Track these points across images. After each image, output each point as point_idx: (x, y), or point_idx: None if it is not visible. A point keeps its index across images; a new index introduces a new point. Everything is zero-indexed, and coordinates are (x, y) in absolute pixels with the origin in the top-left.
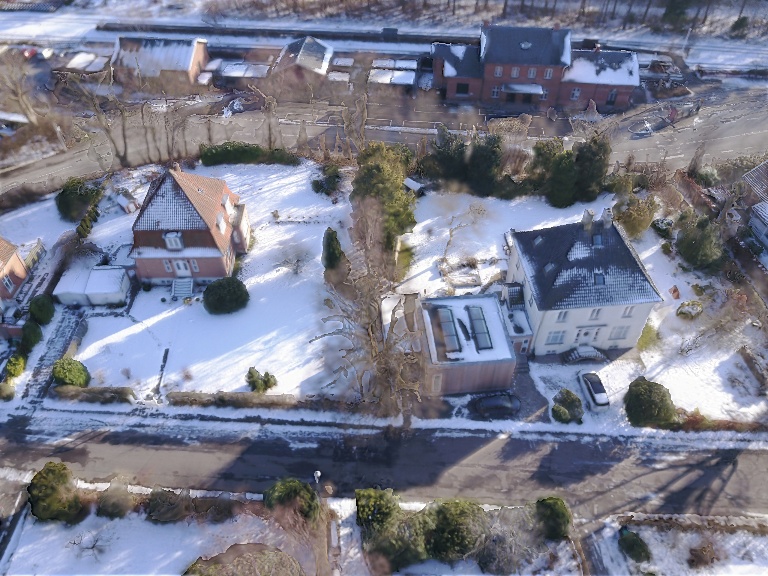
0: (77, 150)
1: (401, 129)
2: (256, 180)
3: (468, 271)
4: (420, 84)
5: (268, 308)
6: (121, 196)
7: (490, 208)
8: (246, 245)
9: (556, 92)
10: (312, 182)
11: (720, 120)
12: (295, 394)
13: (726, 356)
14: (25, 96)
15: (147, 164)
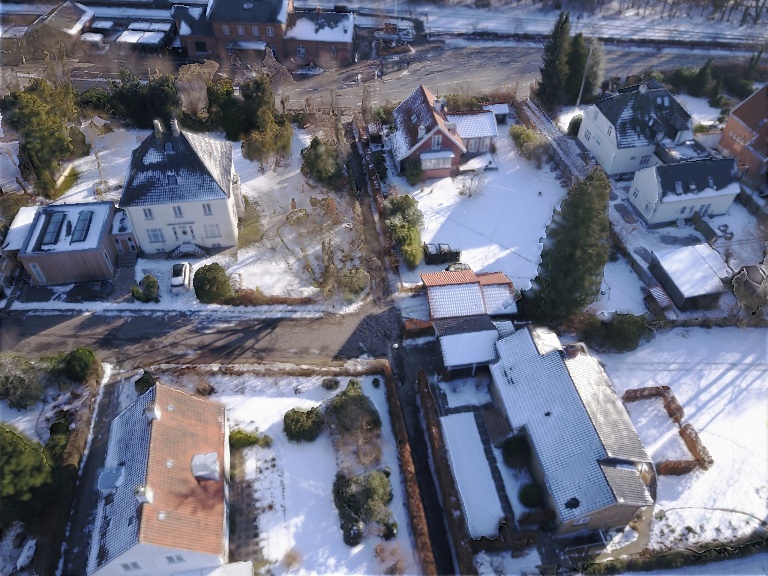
0: None
1: None
2: None
3: None
4: (173, 45)
5: None
6: None
7: None
8: None
9: (282, 49)
10: None
11: (425, 73)
12: None
13: (311, 251)
14: None
15: None
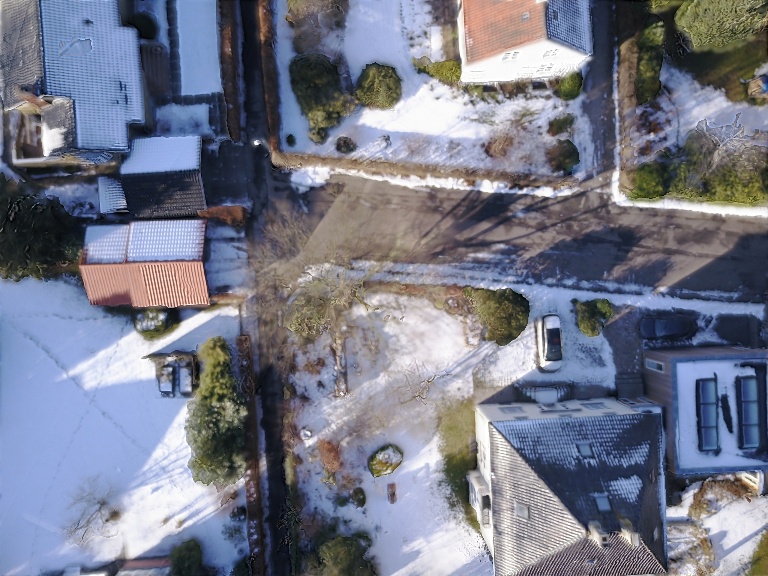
0: None
1: None
2: None
3: None
4: None
5: None
6: None
7: None
8: None
9: None
10: None
11: None
12: None
13: (366, 387)
14: None
15: None
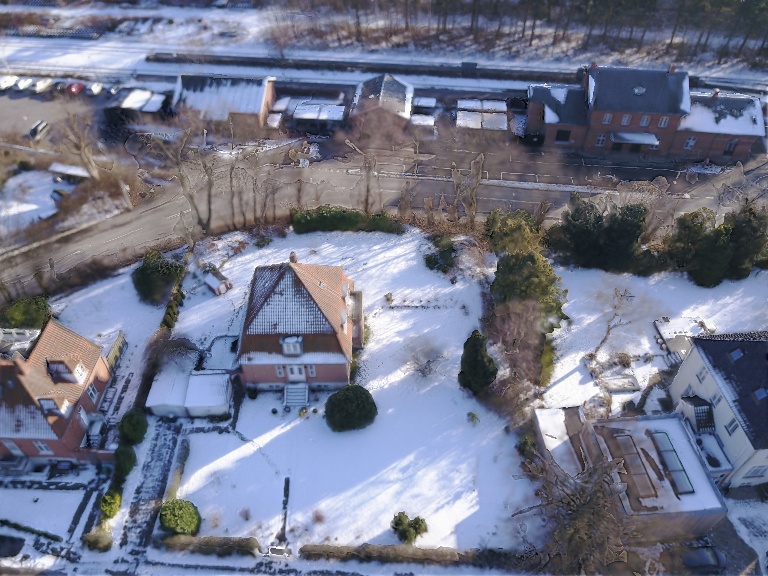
0: (144, 208)
1: (501, 183)
2: (358, 252)
3: (621, 371)
4: (510, 127)
5: (399, 422)
6: (210, 275)
7: (629, 288)
8: (362, 339)
9: (669, 141)
10: (426, 257)
11: None
12: (451, 543)
13: None
14: (87, 148)
15: (231, 231)
